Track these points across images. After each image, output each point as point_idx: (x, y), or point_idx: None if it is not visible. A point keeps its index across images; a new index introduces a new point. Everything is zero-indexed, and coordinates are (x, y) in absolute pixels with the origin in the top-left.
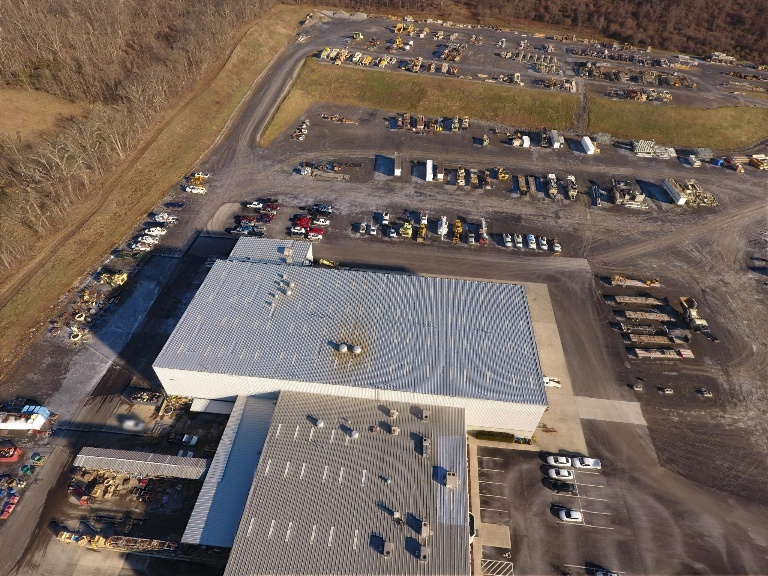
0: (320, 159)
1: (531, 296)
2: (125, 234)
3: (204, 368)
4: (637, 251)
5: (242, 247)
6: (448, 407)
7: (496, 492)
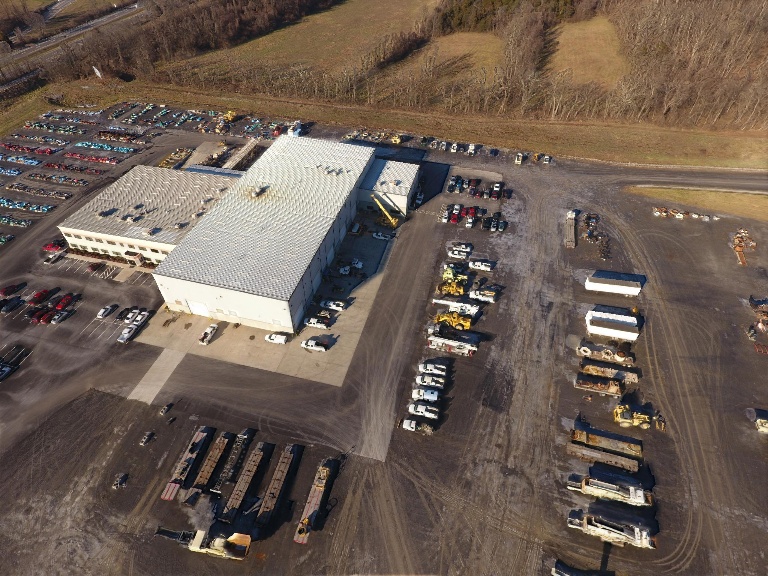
0: (611, 228)
1: None
2: (454, 139)
3: (271, 147)
4: (398, 568)
5: (403, 165)
6: None
7: (147, 281)
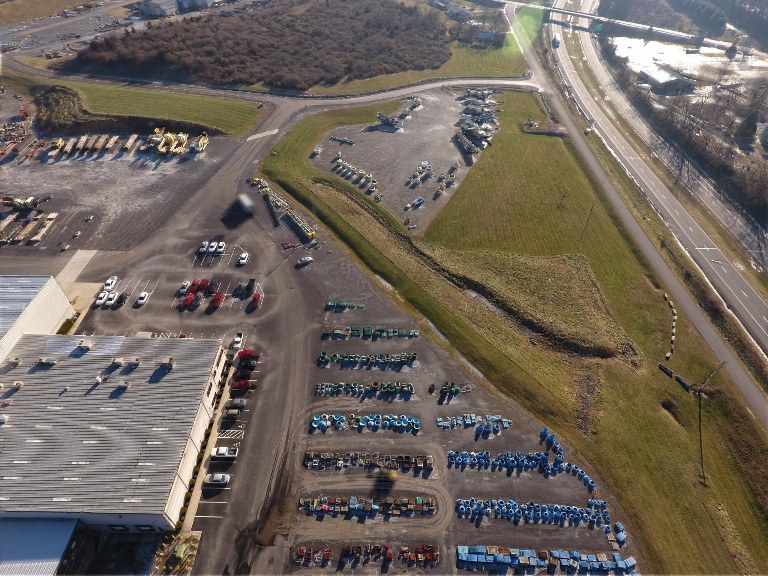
0: None
1: None
2: None
3: None
4: None
5: None
6: (15, 346)
7: None
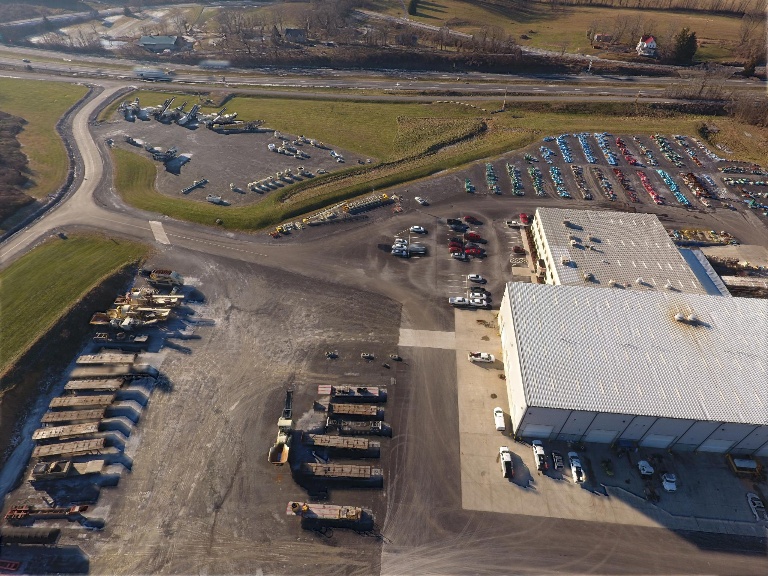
0: None
1: (488, 480)
2: None
3: None
4: None
5: None
6: None
7: None
